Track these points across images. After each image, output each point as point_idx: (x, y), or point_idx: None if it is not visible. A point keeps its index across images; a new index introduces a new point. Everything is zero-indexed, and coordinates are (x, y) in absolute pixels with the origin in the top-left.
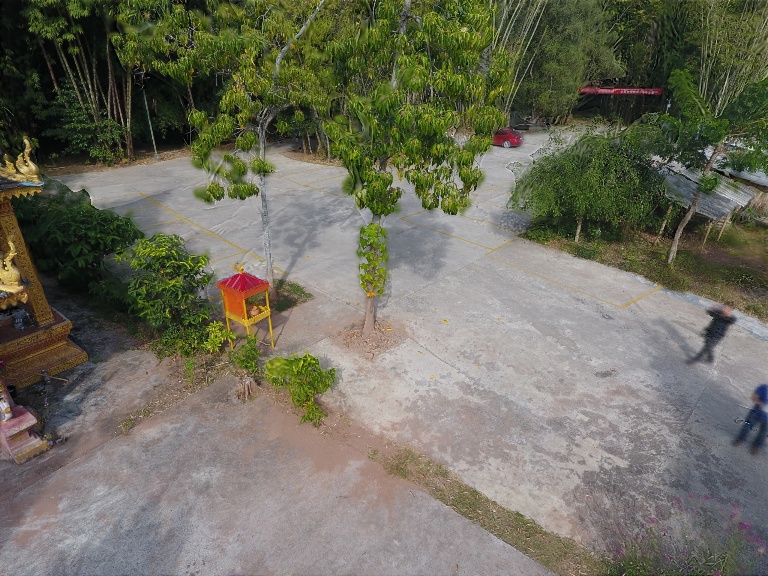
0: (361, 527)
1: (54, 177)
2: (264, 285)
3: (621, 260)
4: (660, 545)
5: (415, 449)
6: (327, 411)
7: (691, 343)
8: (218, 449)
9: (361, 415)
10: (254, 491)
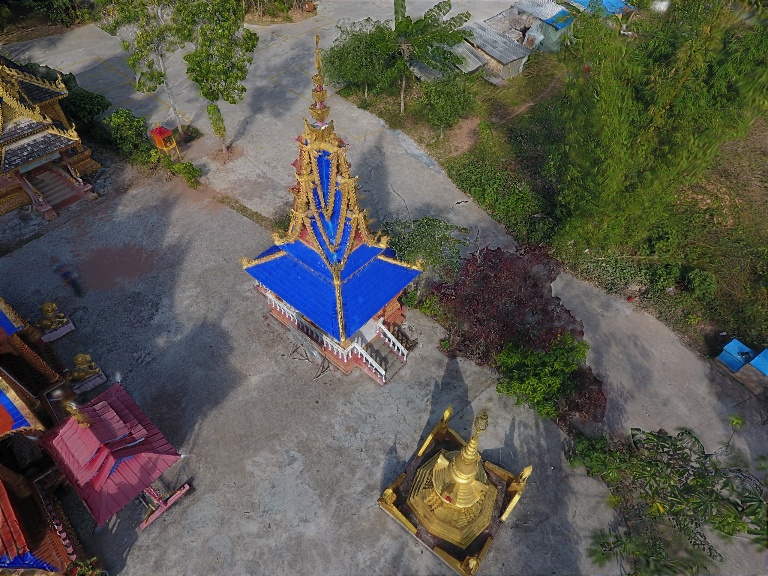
0: (205, 215)
1: (31, 41)
2: (170, 132)
3: (382, 110)
4: None
5: (230, 196)
6: (200, 184)
7: (372, 156)
8: (159, 197)
9: (213, 186)
10: (171, 207)
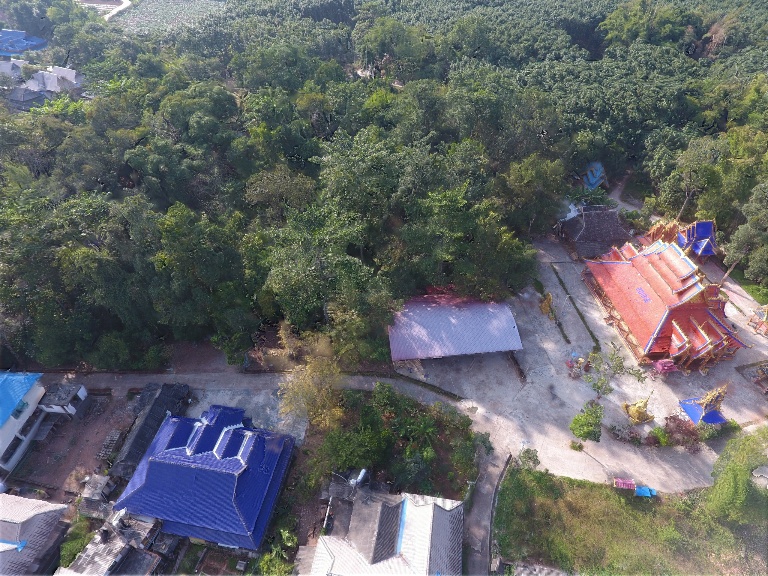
0: (748, 413)
1: None
2: None
3: None
4: None
5: (760, 423)
6: None
7: None
8: None
9: None
10: None
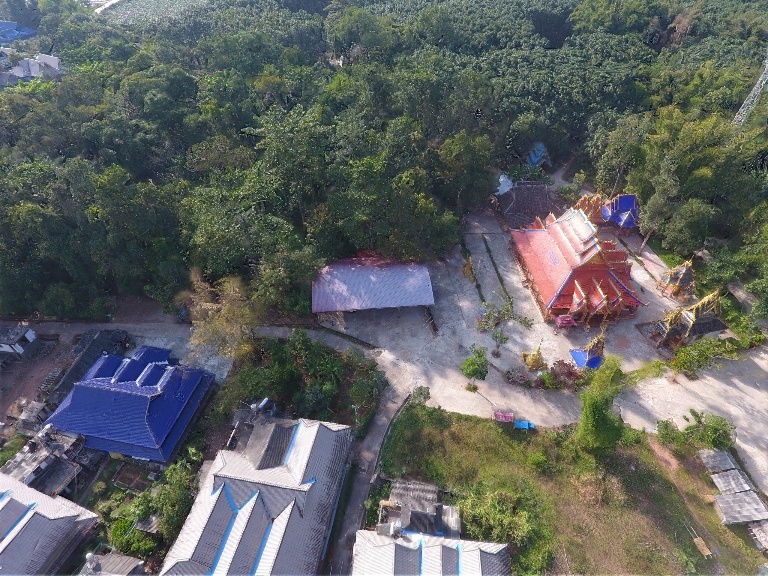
0: (637, 363)
1: None
2: None
3: None
4: (627, 380)
5: None
6: None
7: None
8: None
9: None
10: None
